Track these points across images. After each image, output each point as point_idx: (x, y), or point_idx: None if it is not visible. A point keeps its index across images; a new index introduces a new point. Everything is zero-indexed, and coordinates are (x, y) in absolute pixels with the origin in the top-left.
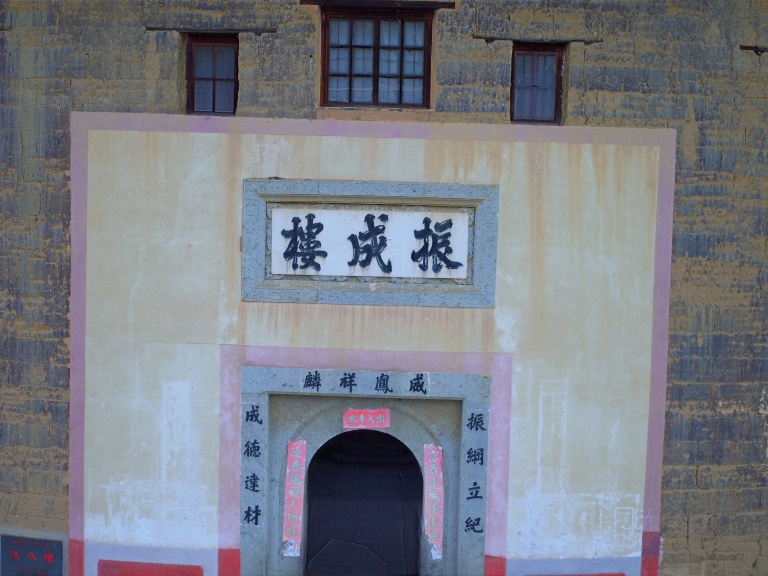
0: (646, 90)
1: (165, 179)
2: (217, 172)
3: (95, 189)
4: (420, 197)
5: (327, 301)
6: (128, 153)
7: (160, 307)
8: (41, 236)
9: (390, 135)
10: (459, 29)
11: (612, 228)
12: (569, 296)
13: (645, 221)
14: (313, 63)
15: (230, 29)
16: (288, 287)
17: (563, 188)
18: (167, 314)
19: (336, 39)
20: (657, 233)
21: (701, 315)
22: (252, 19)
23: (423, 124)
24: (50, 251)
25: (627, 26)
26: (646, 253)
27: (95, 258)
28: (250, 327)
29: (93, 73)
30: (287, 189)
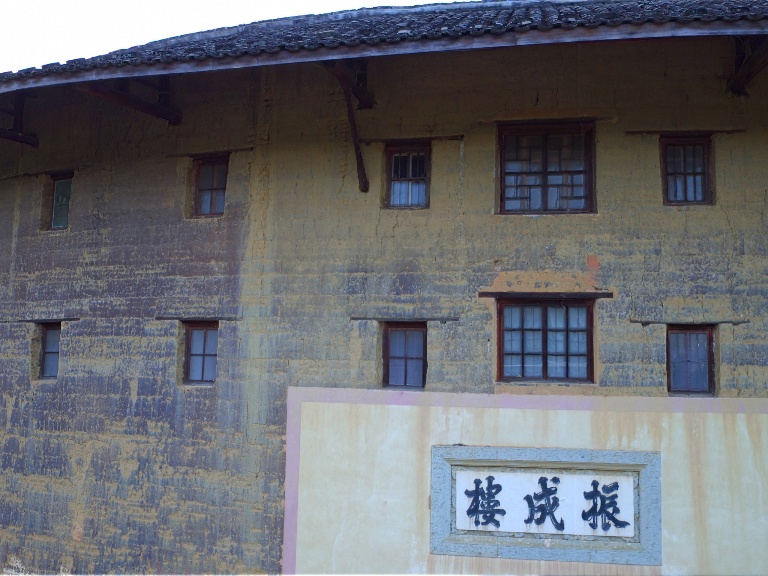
0: None
1: (365, 444)
2: (409, 439)
3: (306, 452)
4: (588, 462)
5: (506, 556)
6: (334, 422)
7: (359, 557)
8: (260, 491)
9: (559, 407)
10: (617, 315)
11: None
12: (733, 555)
13: None
14: (491, 346)
15: (420, 318)
16: (471, 542)
17: (721, 454)
18: (365, 563)
19: (509, 323)
20: None
21: None
22: (438, 310)
23: (588, 397)
24: (267, 504)
25: None
26: None
27: (305, 512)
28: None
29: (307, 355)
30: (470, 454)
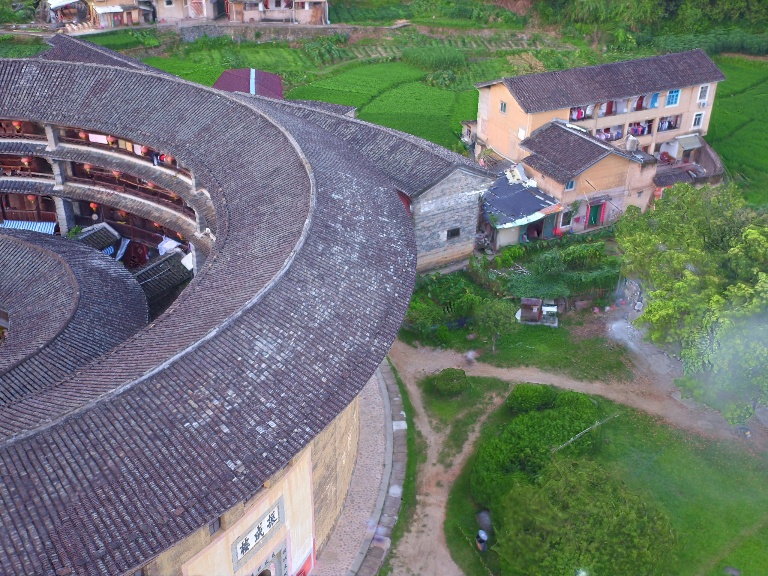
0: None
1: None
2: None
3: None
4: None
5: None
6: None
7: None
8: None
9: None
10: None
11: None
12: None
13: None
14: None
15: None
16: (244, 560)
17: None
18: None
19: None
20: None
21: None
22: None
23: None
24: None
25: None
26: None
27: None
28: None
29: None
30: None
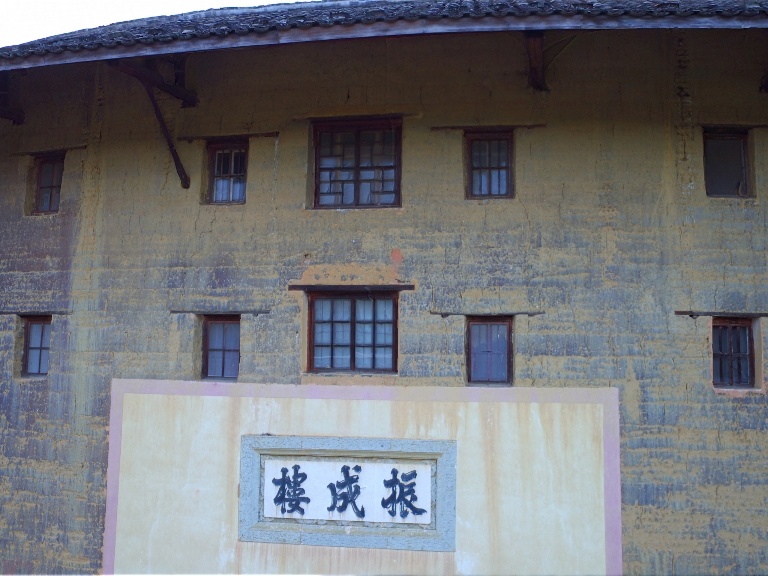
0: (587, 354)
1: (181, 434)
2: (221, 429)
3: (127, 442)
4: (387, 451)
5: (309, 542)
6: (153, 413)
7: (173, 544)
8: (85, 480)
9: (361, 397)
10: (418, 307)
11: (561, 479)
12: (524, 542)
13: (593, 472)
14: (299, 338)
15: (234, 311)
16: (276, 529)
17: (514, 442)
18: (178, 550)
19: (321, 316)
20: (605, 483)
21: (655, 561)
22: (251, 303)
23: (389, 388)
24: (91, 493)
25: (566, 299)
26: (596, 502)
27: (125, 500)
28: (244, 564)
29: (130, 348)
30: (276, 444)
